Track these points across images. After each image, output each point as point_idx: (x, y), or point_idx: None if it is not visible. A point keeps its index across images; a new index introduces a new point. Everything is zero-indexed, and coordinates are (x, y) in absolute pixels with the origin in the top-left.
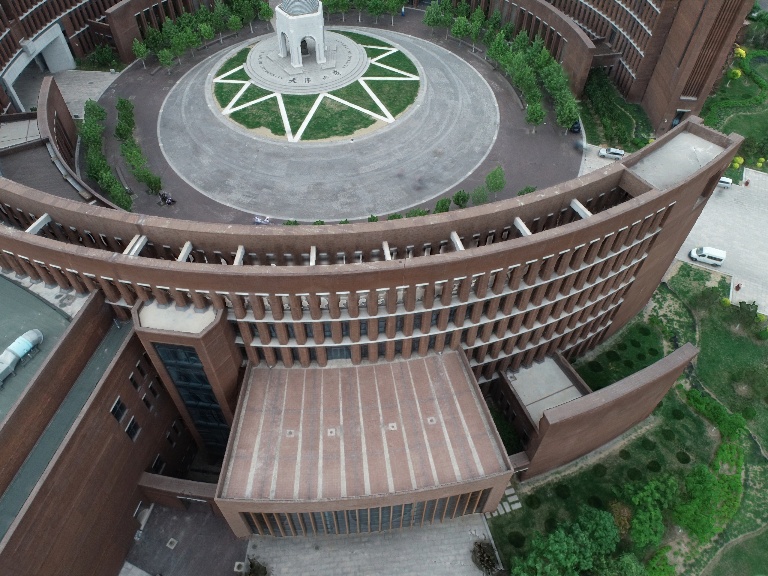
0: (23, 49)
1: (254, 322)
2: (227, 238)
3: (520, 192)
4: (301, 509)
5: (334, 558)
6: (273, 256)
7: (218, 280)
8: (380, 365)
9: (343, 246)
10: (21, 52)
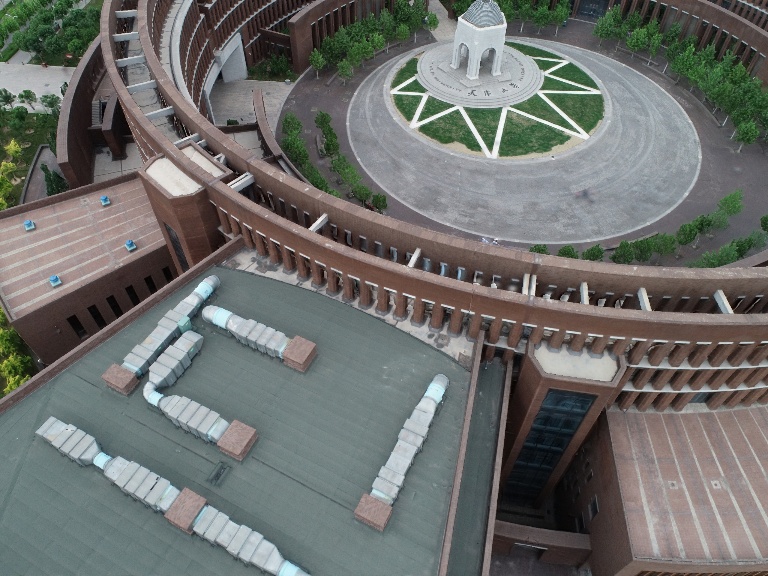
0: (215, 59)
1: (647, 368)
2: (633, 280)
3: (764, 217)
4: (715, 570)
5: None
6: (669, 299)
7: (647, 327)
8: (738, 411)
9: (749, 290)
10: (213, 62)
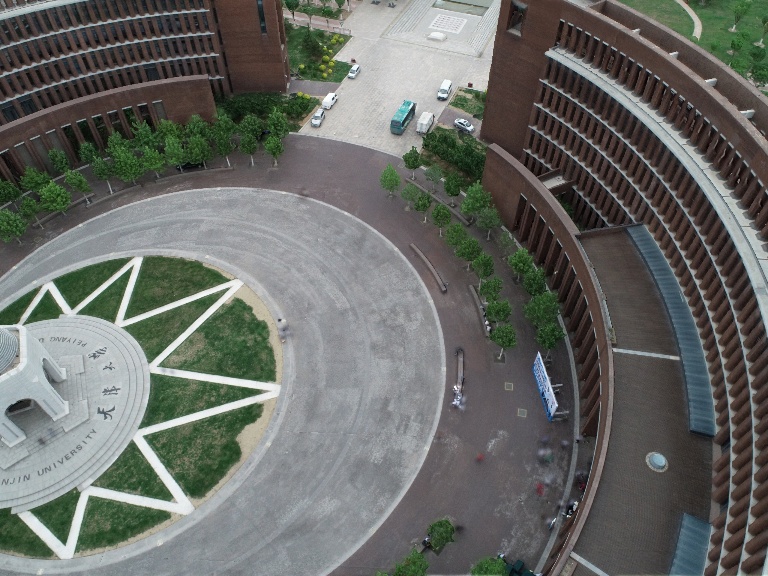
0: None
1: None
2: None
3: (412, 162)
4: None
5: None
6: None
7: None
8: None
9: None
10: None
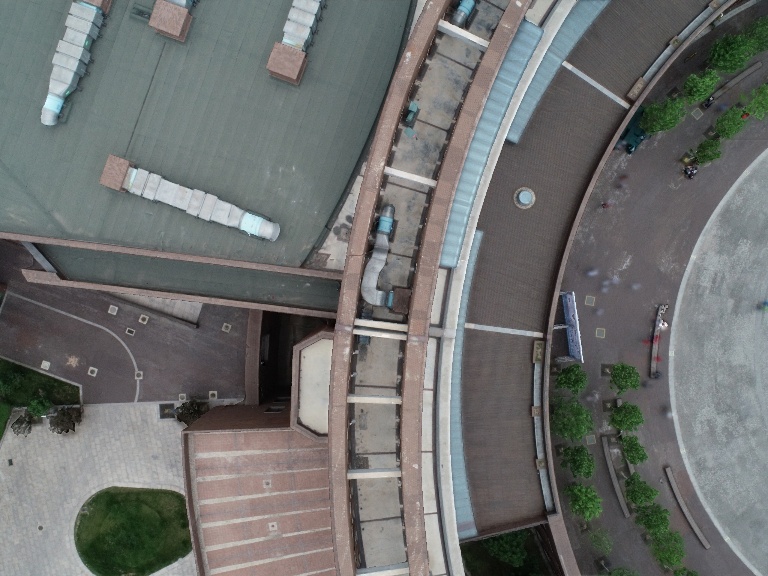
0: None
1: None
2: None
3: None
4: None
5: None
6: None
7: None
8: None
9: None
10: None
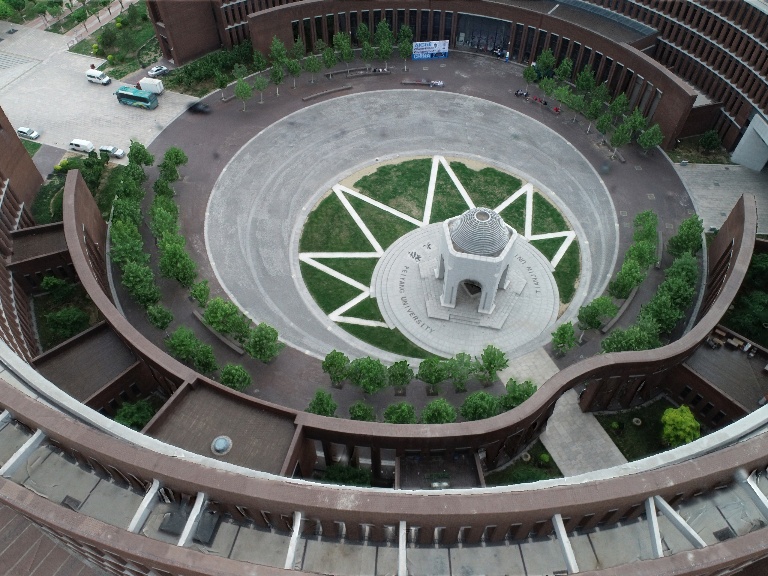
0: None
1: None
2: None
3: None
4: None
5: None
6: None
7: None
8: None
9: None
10: None
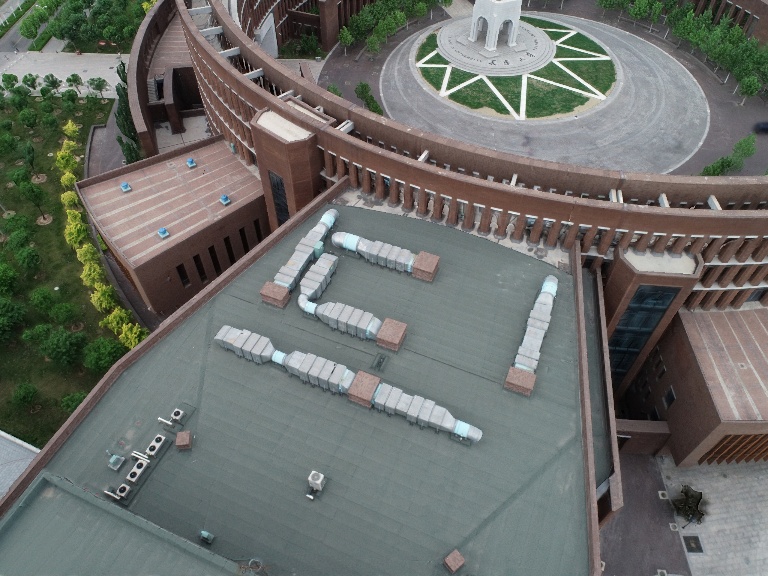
0: (255, 38)
1: (718, 265)
2: (705, 189)
3: None
4: None
5: (744, 484)
6: (733, 205)
7: (724, 224)
8: None
9: None
10: None
